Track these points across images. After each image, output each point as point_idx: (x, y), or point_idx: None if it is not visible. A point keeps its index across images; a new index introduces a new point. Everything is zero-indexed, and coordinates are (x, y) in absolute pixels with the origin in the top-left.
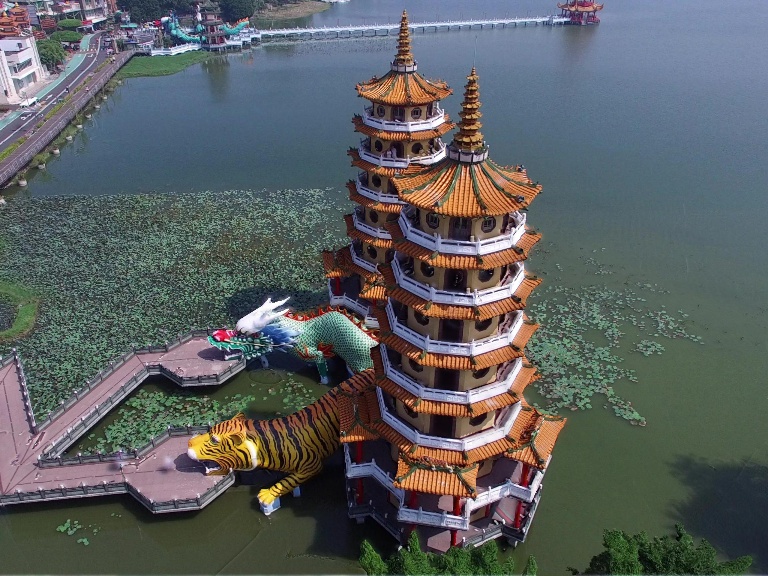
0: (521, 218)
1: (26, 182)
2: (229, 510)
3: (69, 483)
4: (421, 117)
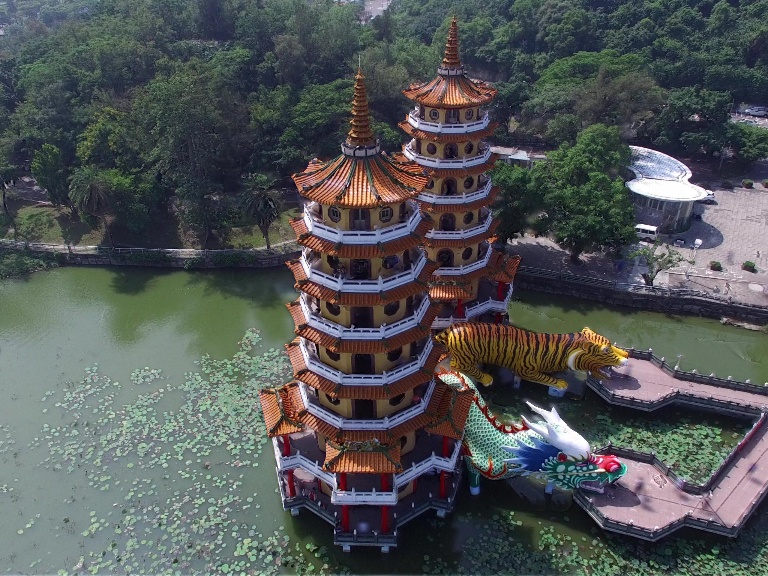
0: None
1: None
2: None
3: (730, 395)
4: None
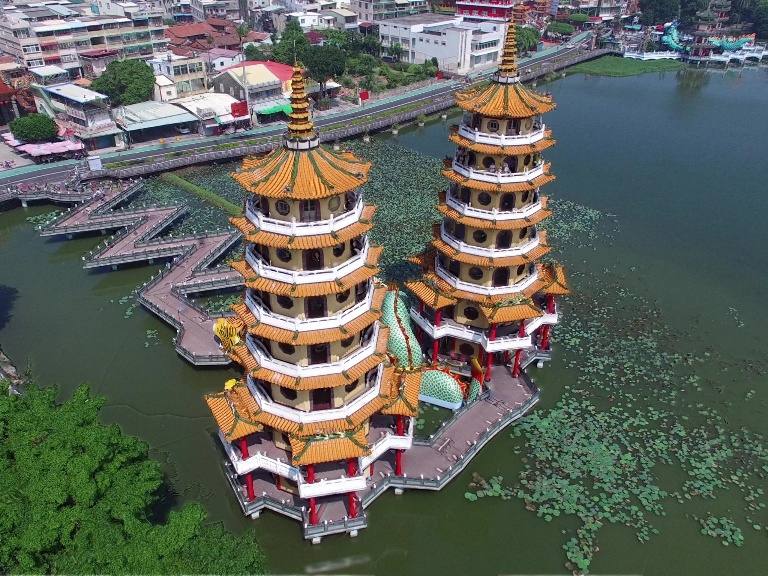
0: (334, 219)
1: (397, 132)
2: (222, 383)
3: (169, 309)
4: (498, 131)
